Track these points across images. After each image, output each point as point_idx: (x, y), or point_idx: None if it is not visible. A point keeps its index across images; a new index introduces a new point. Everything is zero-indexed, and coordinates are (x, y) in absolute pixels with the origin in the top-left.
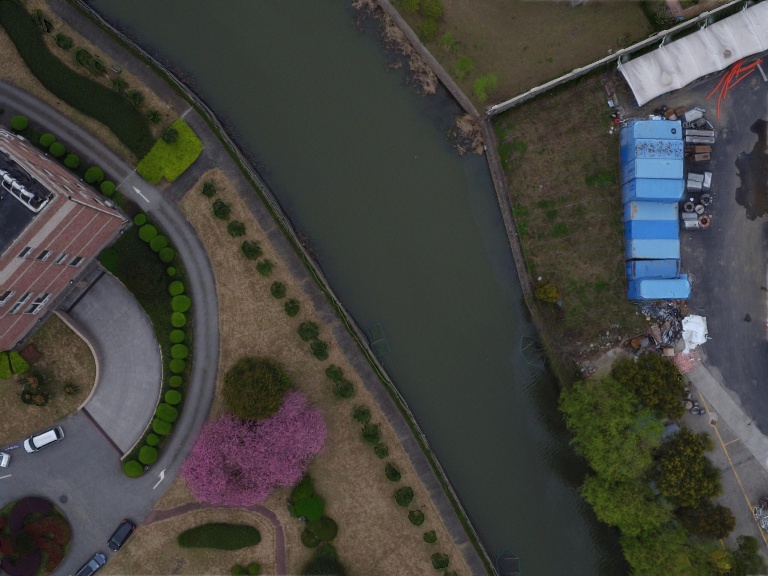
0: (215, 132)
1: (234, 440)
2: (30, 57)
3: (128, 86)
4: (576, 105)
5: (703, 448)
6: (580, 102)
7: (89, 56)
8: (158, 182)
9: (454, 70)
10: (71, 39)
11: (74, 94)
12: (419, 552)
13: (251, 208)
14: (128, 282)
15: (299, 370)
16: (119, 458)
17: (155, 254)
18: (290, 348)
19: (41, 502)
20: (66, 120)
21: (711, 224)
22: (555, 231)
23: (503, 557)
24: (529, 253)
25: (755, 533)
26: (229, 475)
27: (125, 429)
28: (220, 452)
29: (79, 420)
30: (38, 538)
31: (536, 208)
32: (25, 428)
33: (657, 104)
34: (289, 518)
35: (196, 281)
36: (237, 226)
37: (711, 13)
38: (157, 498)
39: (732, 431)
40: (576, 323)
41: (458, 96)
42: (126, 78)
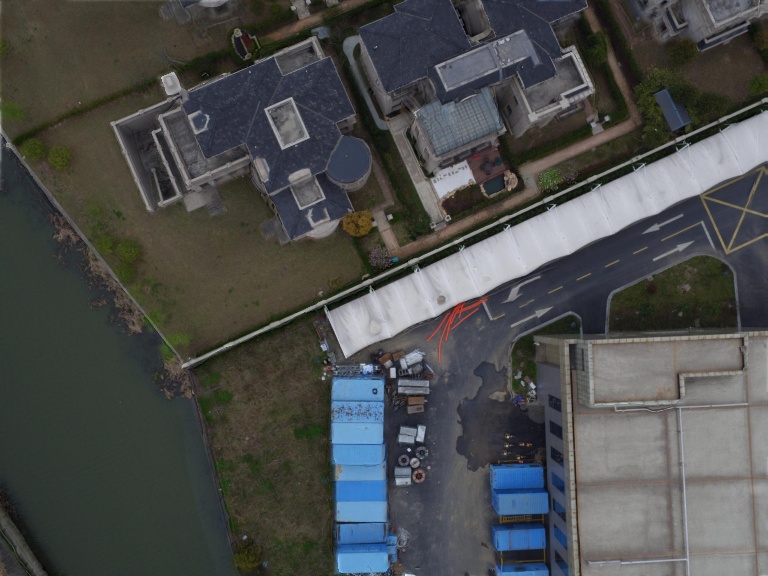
0: None
1: None
2: None
3: None
4: (285, 350)
5: None
6: (290, 347)
7: None
8: None
9: (155, 313)
10: None
11: None
12: None
13: None
14: None
15: None
16: None
17: None
18: None
19: None
20: None
21: (429, 477)
22: (261, 487)
23: None
24: (233, 511)
25: None
26: None
27: None
28: None
29: None
30: None
31: (241, 462)
32: None
33: (371, 349)
34: None
35: None
36: None
37: (421, 259)
38: None
39: None
40: None
41: None
42: None
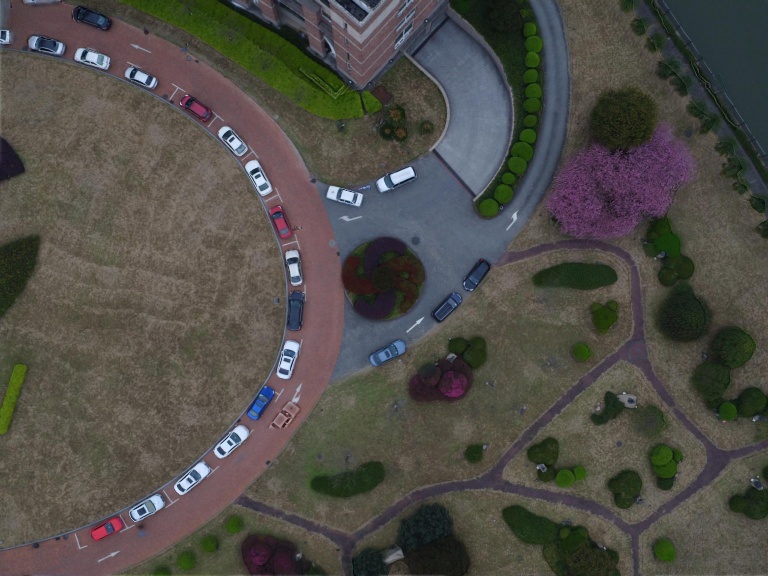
0: None
1: (608, 166)
2: None
3: None
4: None
5: None
6: None
7: None
8: None
9: None
10: None
11: None
12: None
13: None
14: (486, 19)
15: (650, 112)
16: (471, 199)
17: None
18: (641, 91)
19: (396, 241)
20: None
21: None
22: None
23: None
24: None
25: None
26: (603, 201)
27: (476, 171)
28: (593, 179)
29: (430, 162)
30: (396, 276)
31: None
32: (376, 169)
33: None
34: (644, 258)
35: (545, 25)
36: None
37: None
38: (510, 239)
39: None
40: None
41: None
42: None
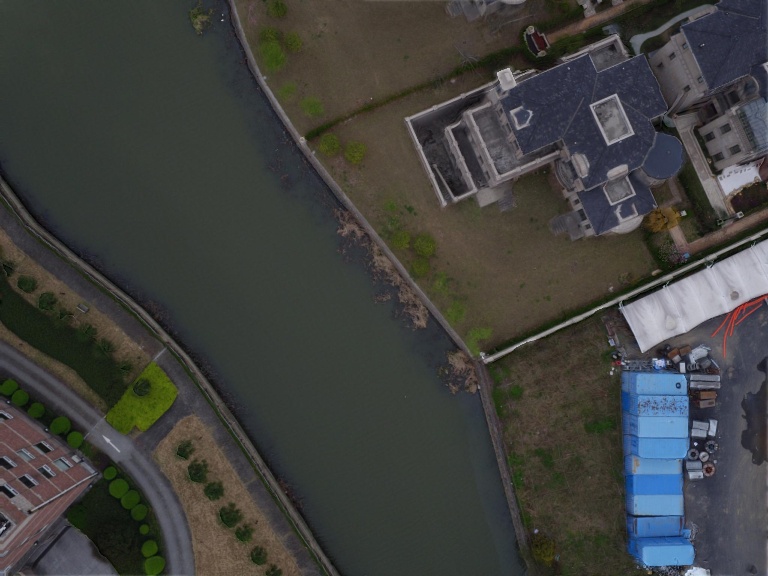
0: (191, 376)
1: None
2: None
3: (96, 331)
4: (575, 345)
5: None
6: (579, 342)
7: (53, 301)
8: (129, 432)
9: (446, 308)
10: (33, 281)
11: (38, 338)
12: None
13: (230, 458)
14: None
15: None
16: None
17: (127, 511)
18: None
19: None
20: (29, 363)
21: (716, 471)
22: (553, 481)
23: None
24: (525, 505)
25: None
26: None
27: None
28: None
29: None
30: None
31: (533, 456)
32: None
33: (660, 344)
34: None
35: (171, 538)
36: (214, 489)
37: (718, 255)
38: None
39: None
40: None
41: (450, 333)
42: (94, 318)
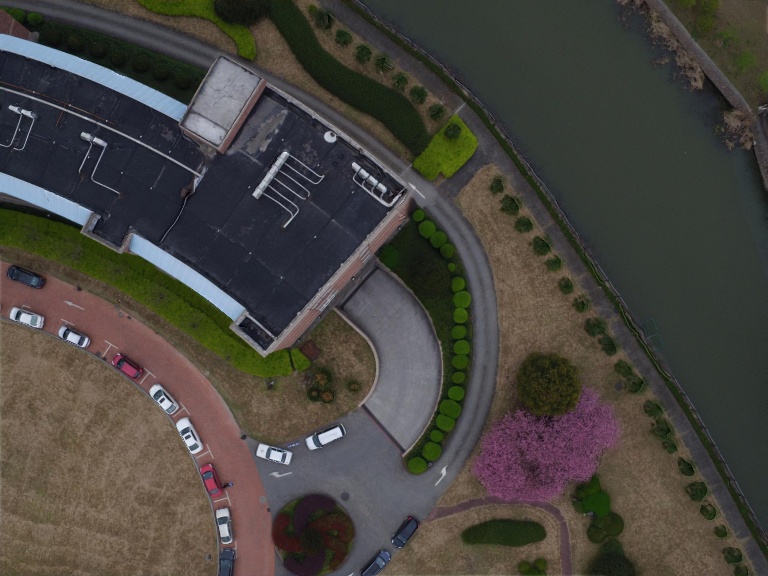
0: (489, 128)
1: (533, 435)
2: (305, 53)
3: (407, 82)
4: None
5: None
6: None
7: (369, 52)
8: (435, 178)
9: (726, 65)
10: (350, 35)
11: (350, 90)
12: (703, 547)
13: (527, 204)
14: (413, 278)
15: (580, 365)
16: (400, 455)
17: (435, 250)
18: (571, 343)
19: (324, 499)
20: (339, 116)
21: None
22: None
23: None
24: None
25: None
26: (528, 471)
27: (405, 426)
28: (517, 448)
29: (359, 417)
30: (324, 536)
31: None
32: (305, 425)
33: None
34: (573, 514)
35: (474, 277)
36: (525, 221)
37: None
38: (439, 495)
39: None
40: None
41: (727, 91)
42: (400, 74)
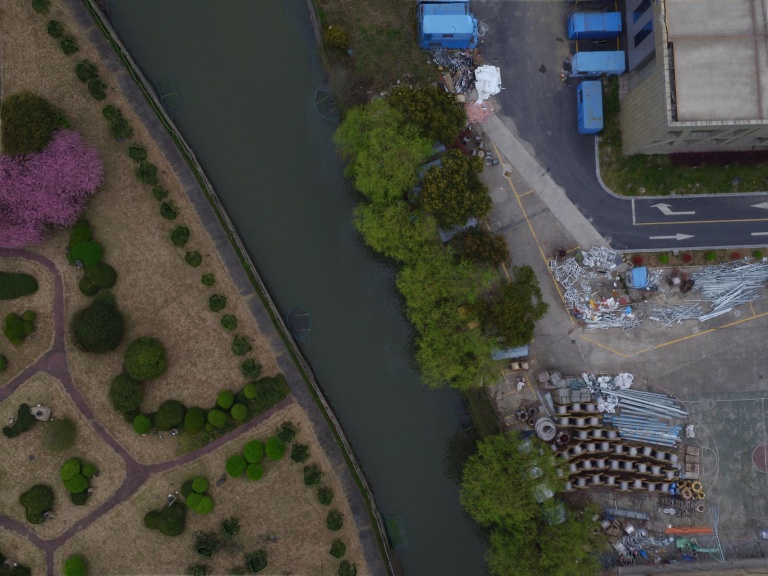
0: None
1: (1, 173)
2: None
3: None
4: None
5: (497, 200)
6: None
7: None
8: None
9: None
10: None
11: None
12: (202, 301)
13: None
14: None
15: (81, 117)
16: None
17: None
18: (72, 95)
19: None
20: None
21: None
22: None
23: (294, 313)
24: (319, 1)
25: (550, 286)
26: None
27: None
28: None
29: None
30: None
31: None
32: None
33: None
34: (68, 267)
35: None
36: None
37: None
38: None
39: (526, 183)
40: (366, 71)
41: None
42: None
